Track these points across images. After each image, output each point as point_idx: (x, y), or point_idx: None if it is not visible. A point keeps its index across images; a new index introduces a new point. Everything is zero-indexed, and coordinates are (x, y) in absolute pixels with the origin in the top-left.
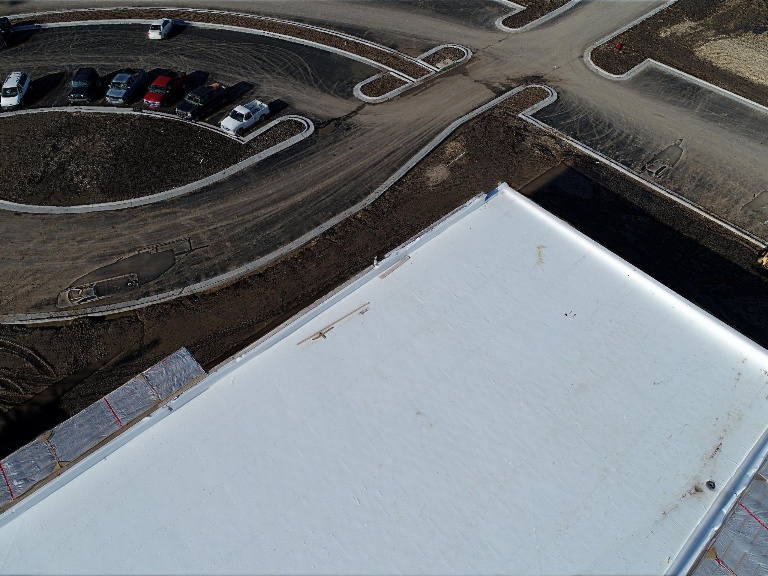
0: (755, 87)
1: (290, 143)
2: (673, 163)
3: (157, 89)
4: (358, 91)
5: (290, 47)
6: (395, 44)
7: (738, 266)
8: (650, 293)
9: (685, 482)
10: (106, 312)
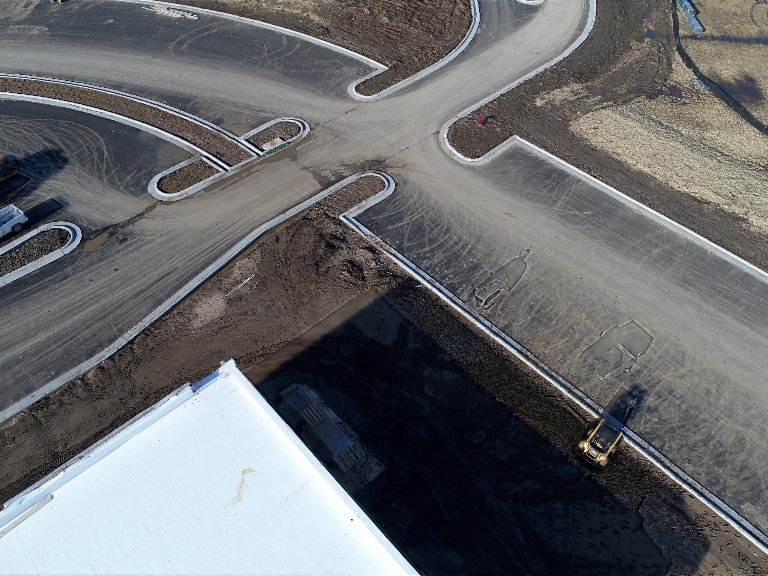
0: (631, 174)
1: (42, 263)
2: (511, 286)
3: None
4: (154, 185)
5: (94, 124)
6: (221, 118)
7: (556, 450)
8: (376, 552)
9: None
10: None
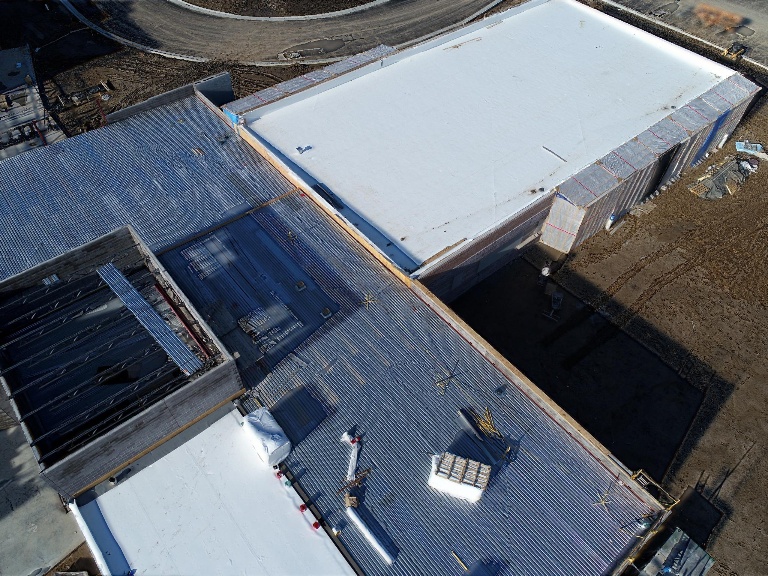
0: None
1: None
2: (672, 11)
3: None
4: None
5: None
6: None
7: None
8: (647, 42)
9: (659, 106)
10: (310, 62)
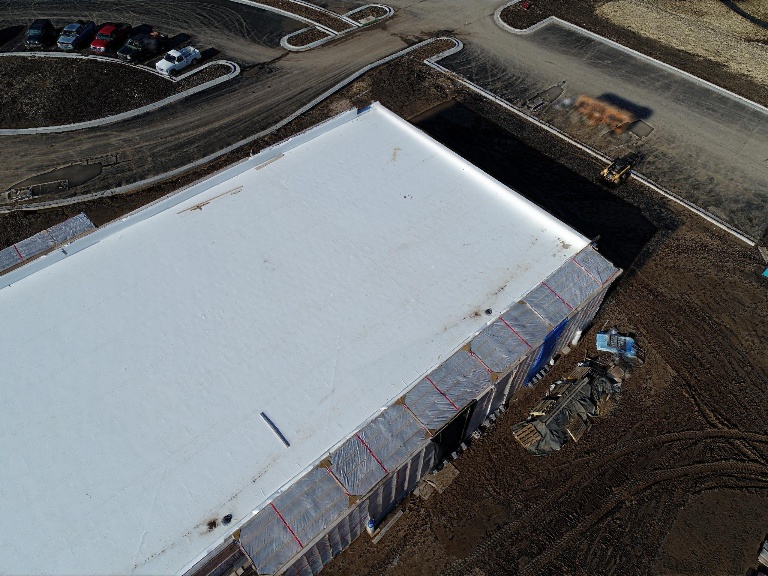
0: (641, 39)
1: (216, 82)
2: (552, 100)
3: (103, 37)
4: (285, 42)
5: (230, 6)
6: (326, 4)
7: (585, 178)
8: (480, 183)
9: (468, 309)
10: (38, 207)
